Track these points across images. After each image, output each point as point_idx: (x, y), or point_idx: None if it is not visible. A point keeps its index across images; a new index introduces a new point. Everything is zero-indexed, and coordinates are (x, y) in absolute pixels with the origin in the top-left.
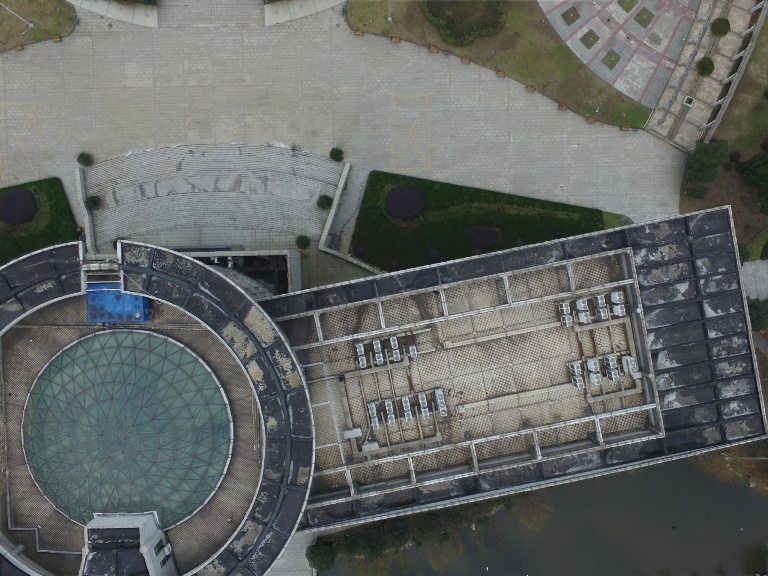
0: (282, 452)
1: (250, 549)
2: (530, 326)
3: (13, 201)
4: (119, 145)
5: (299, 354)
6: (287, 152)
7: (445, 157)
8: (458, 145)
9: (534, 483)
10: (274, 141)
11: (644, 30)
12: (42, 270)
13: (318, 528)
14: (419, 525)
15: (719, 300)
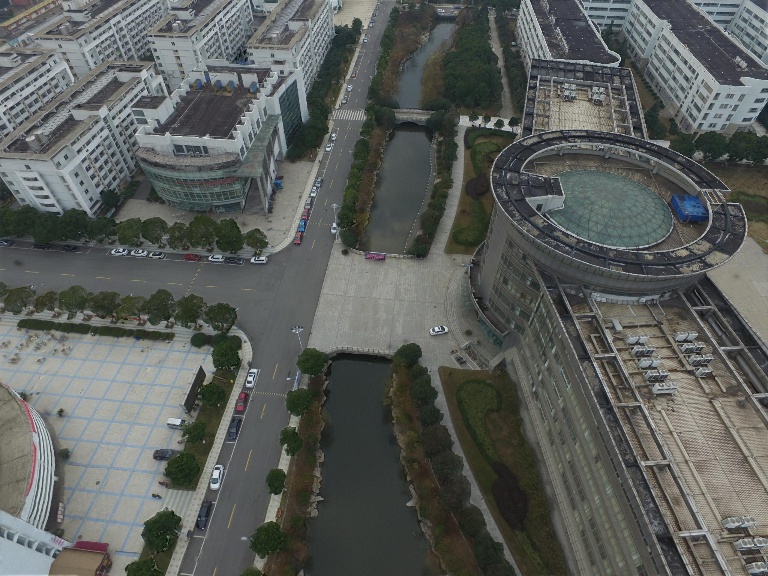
0: None
1: None
2: None
3: None
4: (707, 273)
5: (666, 302)
6: None
7: None
8: None
9: None
10: None
11: None
12: None
13: None
14: None
15: None
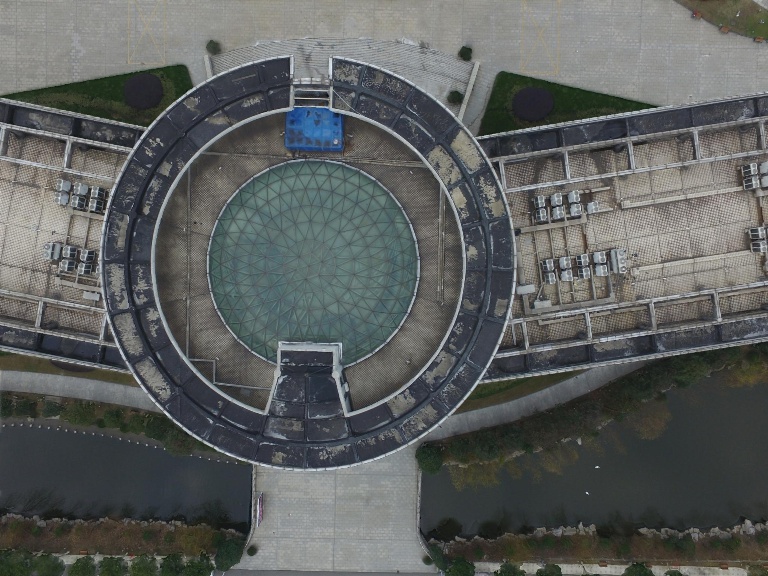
0: (481, 283)
1: (443, 380)
2: (710, 190)
3: (140, 85)
4: (247, 35)
5: None
6: (416, 49)
7: (574, 61)
8: (588, 50)
9: (713, 345)
10: (403, 38)
11: None
12: (250, 84)
13: (492, 379)
14: (537, 428)
15: None
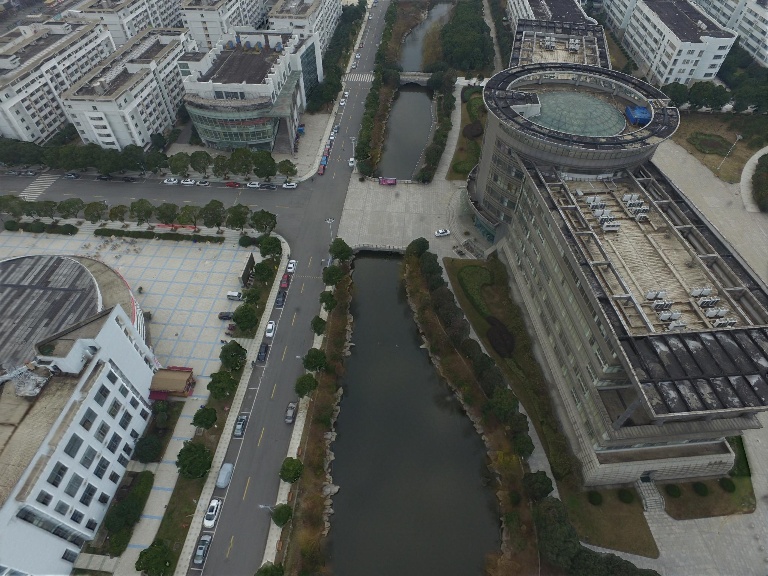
0: None
1: None
2: None
3: None
4: None
5: (618, 180)
6: None
7: None
8: None
9: None
10: None
11: None
12: None
13: None
14: None
15: (767, 389)
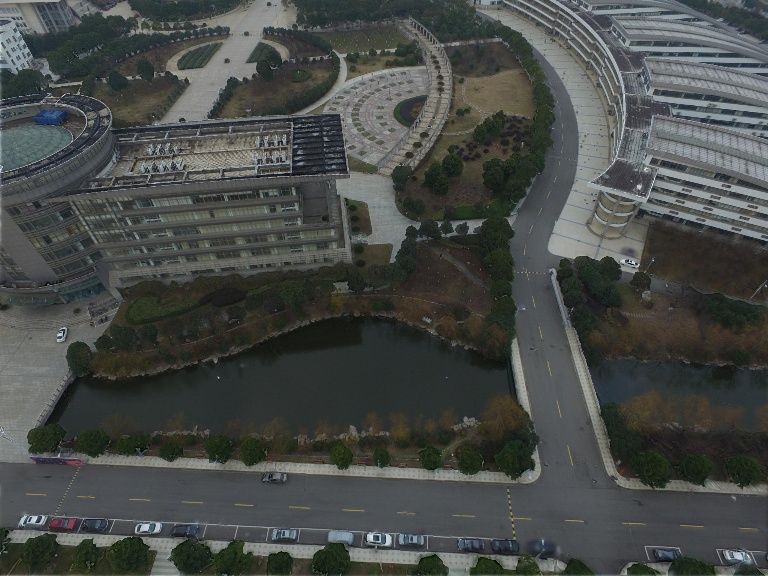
0: None
1: None
2: None
3: None
4: None
5: None
6: None
7: None
8: None
9: None
10: None
11: (380, 146)
12: None
13: None
14: None
15: None
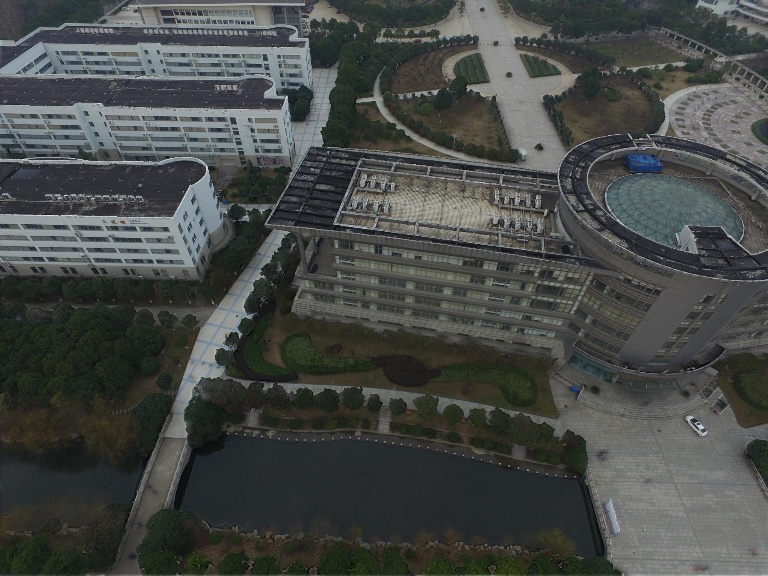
0: None
1: None
2: None
3: None
4: None
5: None
6: None
7: None
8: None
9: None
10: None
11: None
12: None
13: None
14: None
15: None
